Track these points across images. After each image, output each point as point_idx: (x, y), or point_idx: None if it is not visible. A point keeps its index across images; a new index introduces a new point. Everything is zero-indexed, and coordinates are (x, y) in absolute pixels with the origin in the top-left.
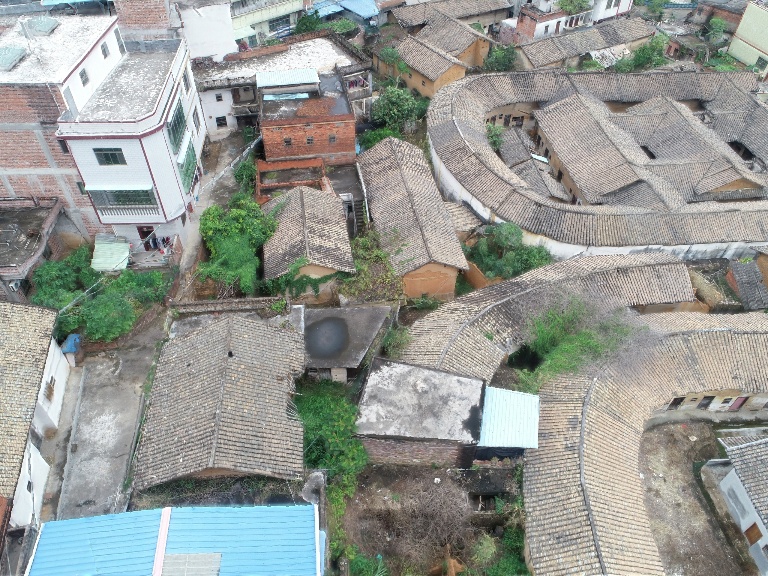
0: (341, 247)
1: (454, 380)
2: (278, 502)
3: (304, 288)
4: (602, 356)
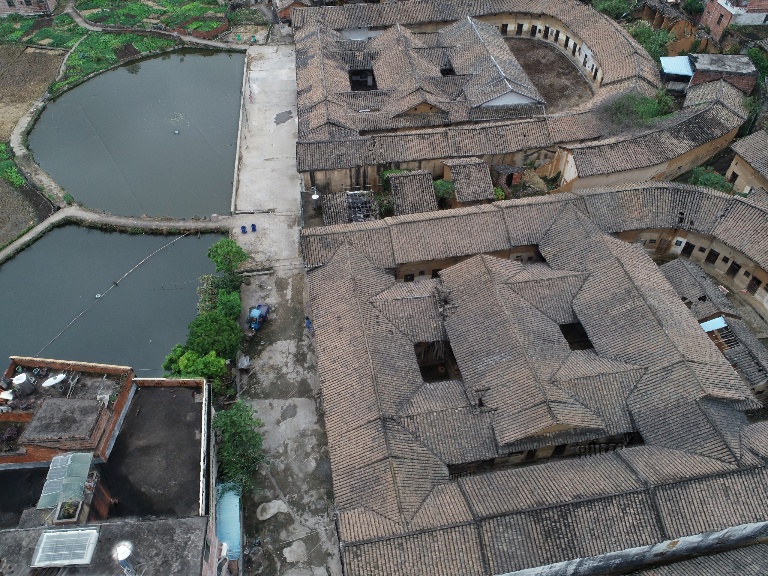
0: None
1: None
2: None
3: None
4: None
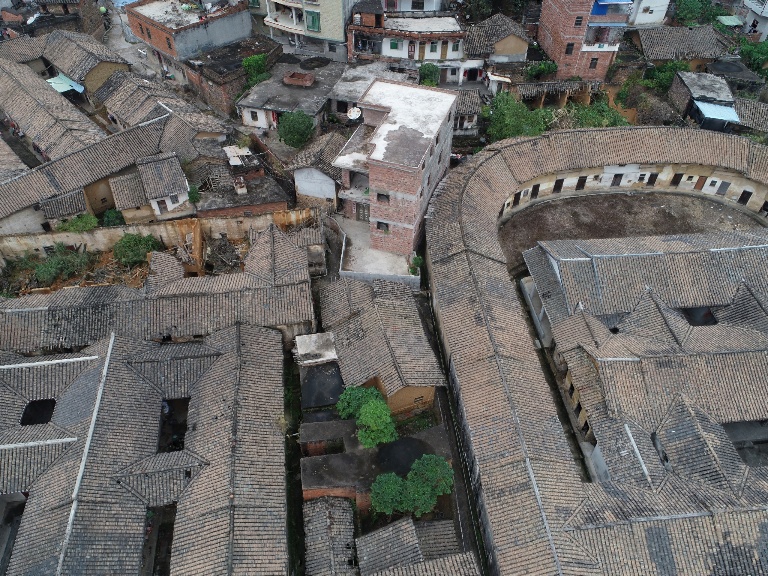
0: None
1: (728, 94)
2: (634, 57)
3: (762, 77)
4: None
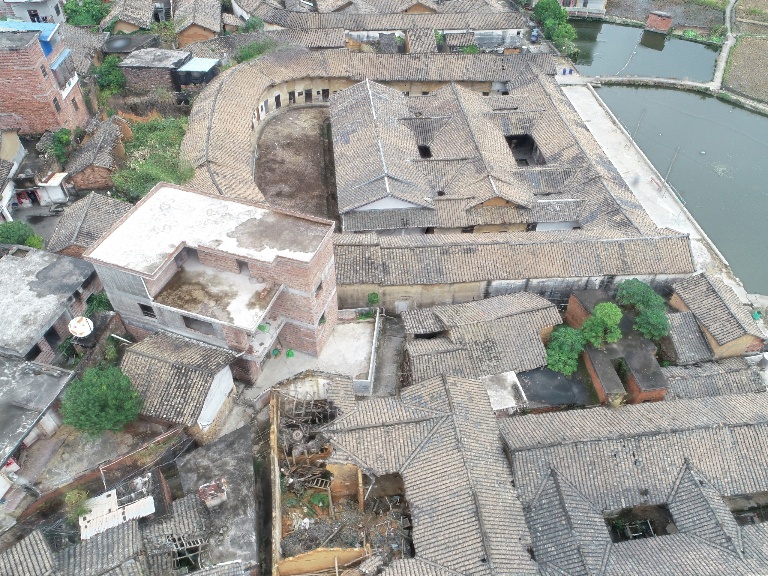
0: (144, 19)
1: (176, 52)
2: None
3: None
4: (266, 53)
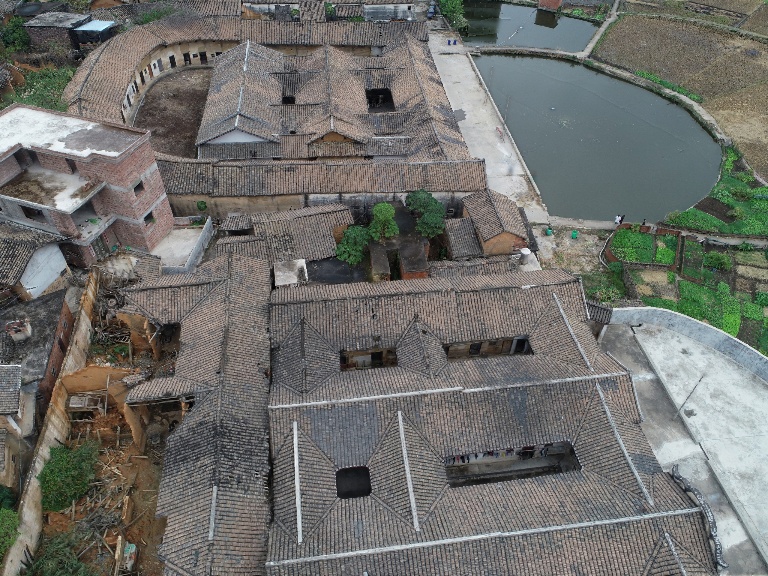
0: None
1: (77, 15)
2: None
3: None
4: (162, 18)
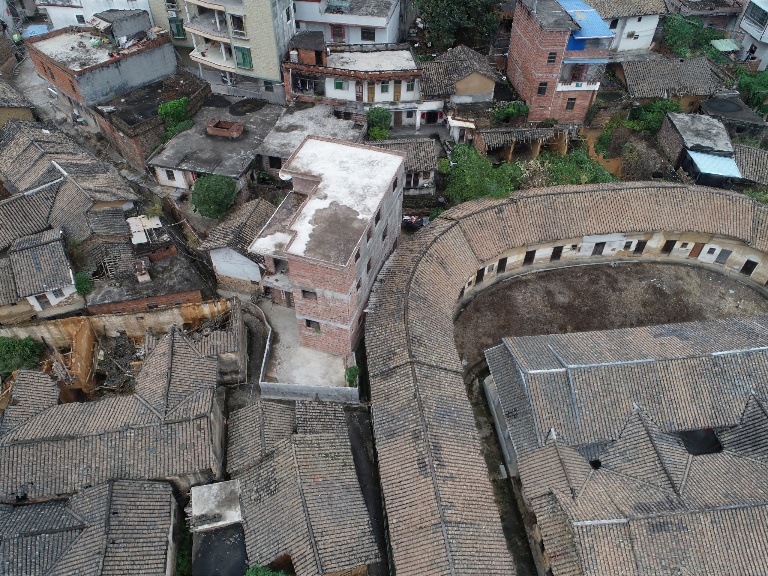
0: None
1: (727, 142)
2: (617, 95)
3: (763, 114)
4: None
